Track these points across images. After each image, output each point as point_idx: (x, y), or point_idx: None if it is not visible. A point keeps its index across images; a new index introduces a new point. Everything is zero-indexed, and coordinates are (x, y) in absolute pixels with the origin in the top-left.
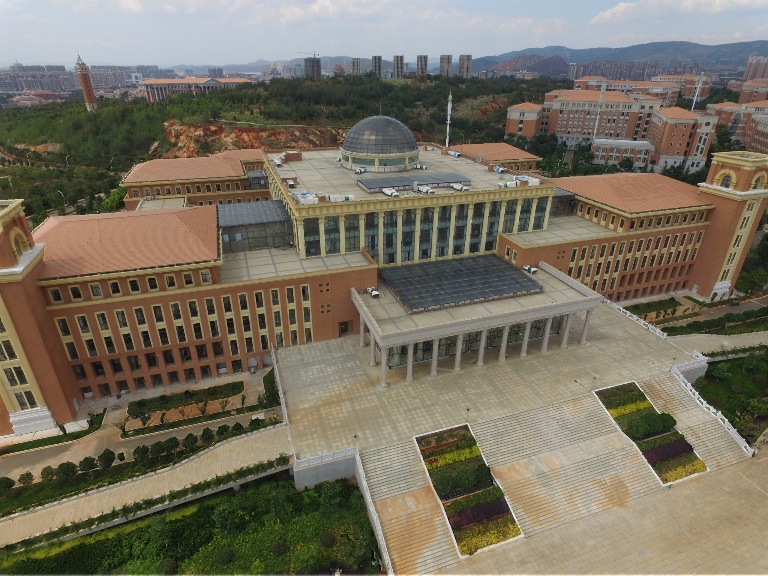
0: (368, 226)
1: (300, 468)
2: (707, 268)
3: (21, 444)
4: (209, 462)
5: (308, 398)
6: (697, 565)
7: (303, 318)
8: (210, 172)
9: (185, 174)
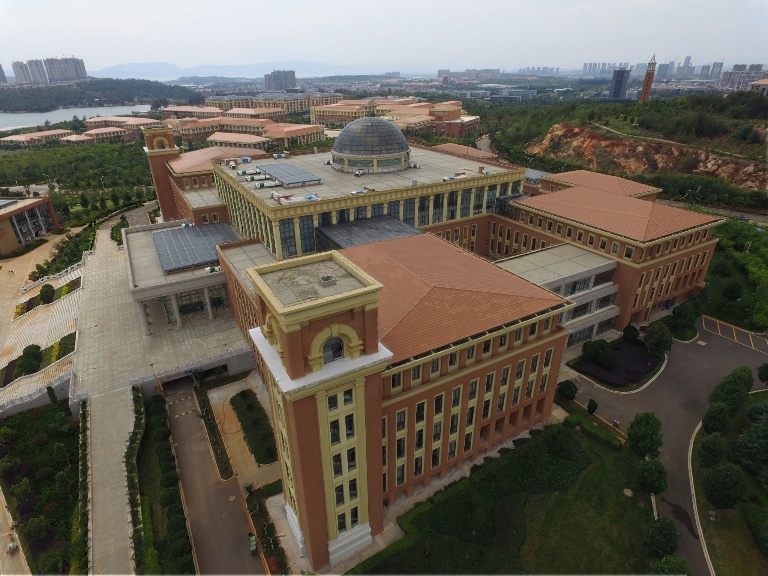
0: None
1: None
2: None
3: None
4: None
5: None
6: None
7: None
8: None
9: None
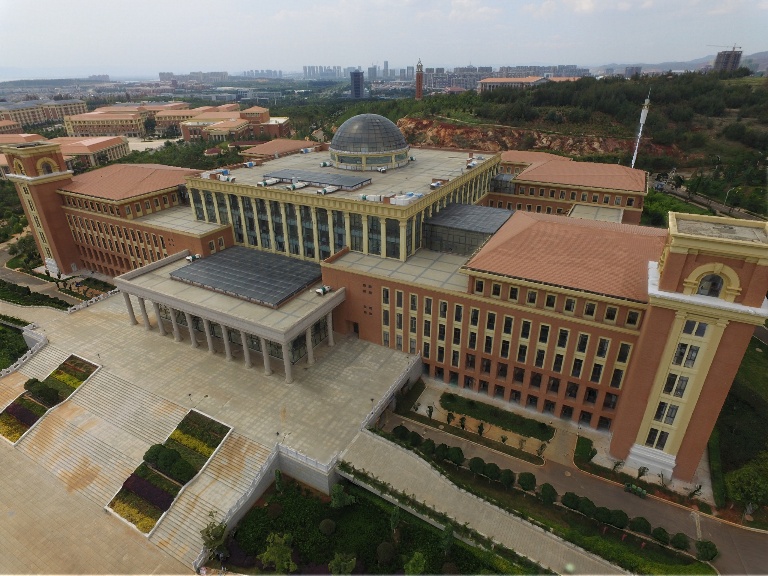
0: (234, 206)
1: (25, 333)
2: None
3: (42, 274)
4: None
5: (102, 308)
6: (3, 553)
7: None
8: None
9: None
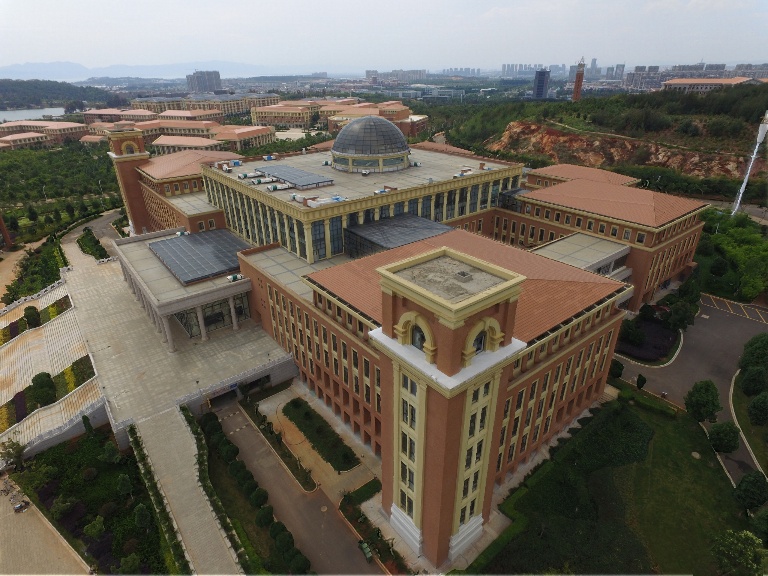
0: None
1: None
2: None
3: None
4: (82, 258)
5: None
6: None
7: None
8: None
9: None
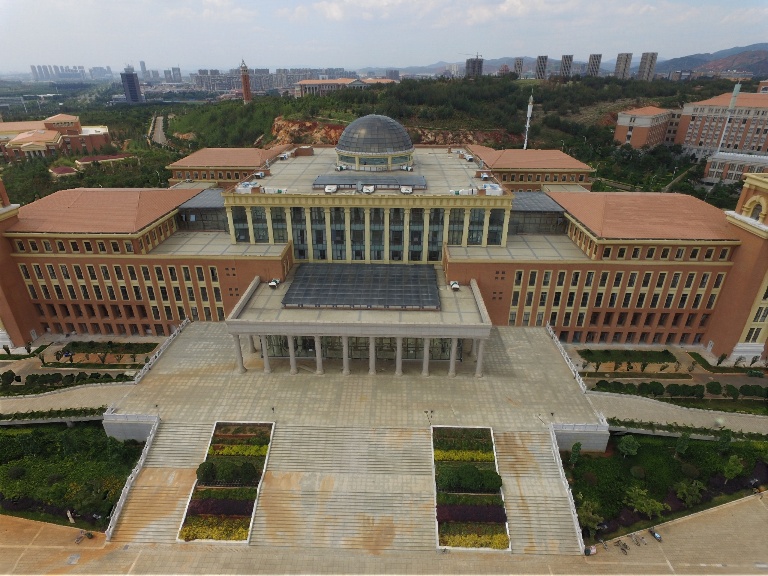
0: (296, 220)
1: (108, 421)
2: (724, 321)
3: None
4: (61, 398)
5: (173, 367)
6: None
7: (214, 297)
8: (241, 161)
9: (220, 162)
